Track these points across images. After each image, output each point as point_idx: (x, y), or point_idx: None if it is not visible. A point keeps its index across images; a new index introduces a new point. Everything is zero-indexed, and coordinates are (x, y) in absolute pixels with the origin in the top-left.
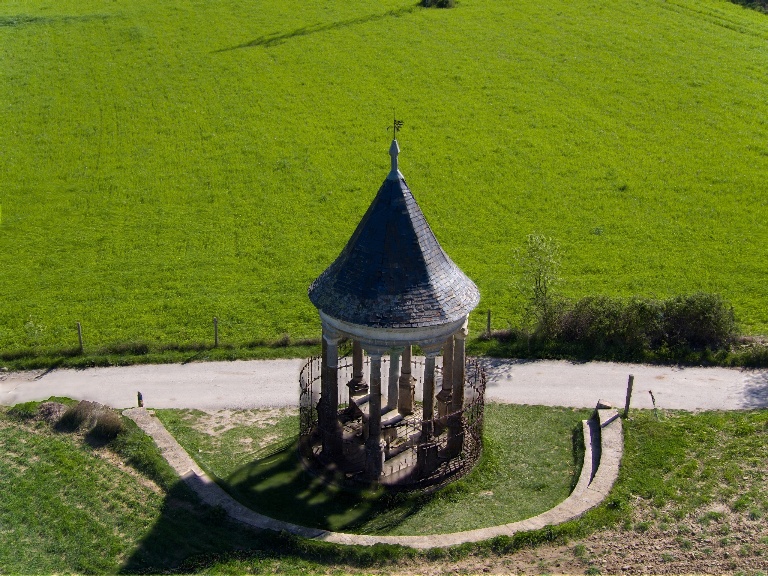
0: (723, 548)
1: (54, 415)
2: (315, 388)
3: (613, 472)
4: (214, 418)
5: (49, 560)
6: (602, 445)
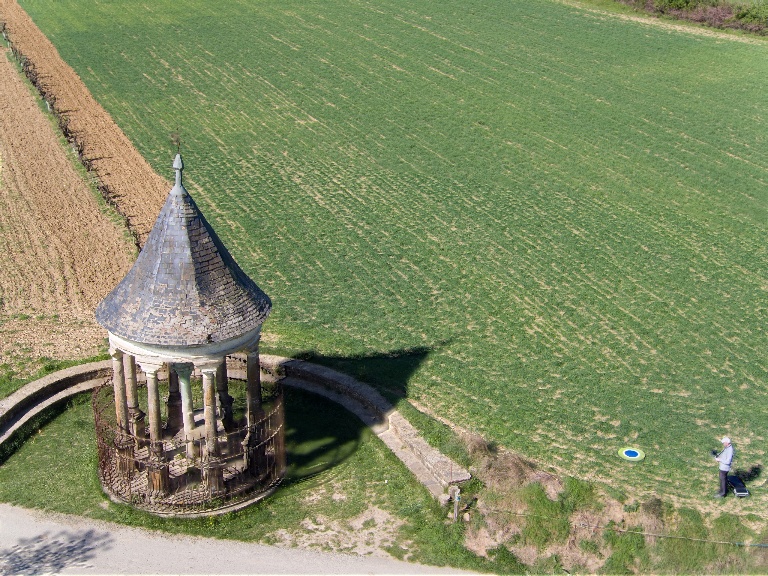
0: (2, 348)
1: (541, 471)
2: (249, 570)
3: (27, 387)
4: (377, 542)
5: (480, 364)
6: (8, 410)
